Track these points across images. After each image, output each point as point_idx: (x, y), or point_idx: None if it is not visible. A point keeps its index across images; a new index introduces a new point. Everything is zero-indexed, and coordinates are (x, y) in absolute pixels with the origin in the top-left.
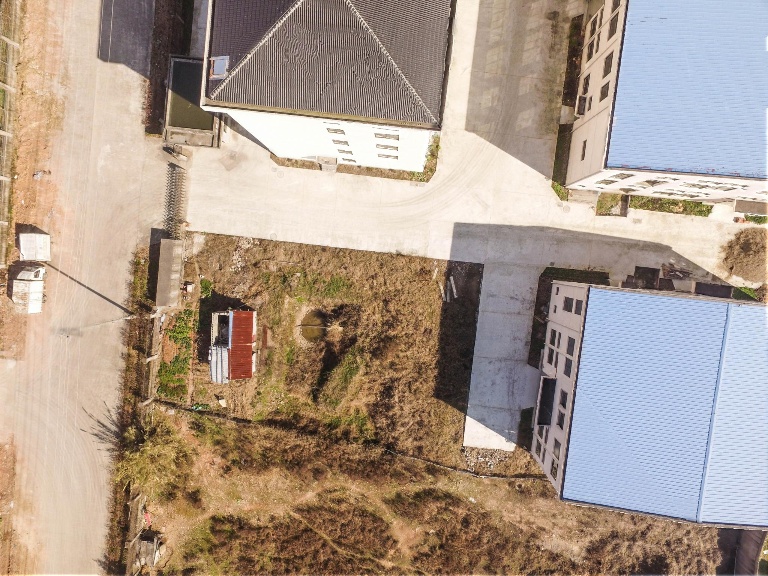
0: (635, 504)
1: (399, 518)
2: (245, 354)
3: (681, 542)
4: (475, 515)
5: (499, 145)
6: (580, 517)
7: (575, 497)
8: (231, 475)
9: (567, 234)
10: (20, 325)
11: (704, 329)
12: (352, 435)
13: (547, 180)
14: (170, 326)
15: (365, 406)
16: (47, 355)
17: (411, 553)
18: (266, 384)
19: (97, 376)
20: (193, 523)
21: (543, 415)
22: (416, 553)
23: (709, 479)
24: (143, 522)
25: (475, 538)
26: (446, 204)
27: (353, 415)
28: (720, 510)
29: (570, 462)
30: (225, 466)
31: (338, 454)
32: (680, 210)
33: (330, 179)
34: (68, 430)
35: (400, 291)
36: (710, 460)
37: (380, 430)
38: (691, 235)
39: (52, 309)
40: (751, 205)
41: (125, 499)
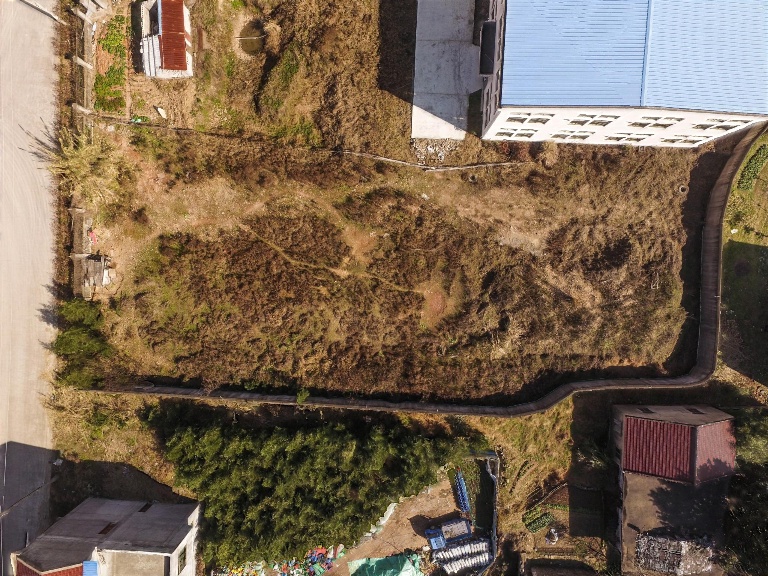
0: (576, 98)
1: (351, 223)
2: (177, 44)
3: (644, 223)
4: (429, 213)
5: None
6: (537, 206)
7: (514, 102)
8: (175, 185)
9: None
10: None
11: None
12: (298, 143)
13: None
14: (102, 35)
15: (310, 113)
16: None
17: (366, 260)
18: (205, 90)
19: (31, 91)
20: (141, 245)
21: (485, 63)
22: (371, 259)
23: (651, 59)
24: (90, 247)
25: (430, 236)
26: None
27: (299, 125)
28: (665, 93)
29: (506, 64)
30: (169, 181)
31: (284, 157)
32: None
33: None
34: (6, 151)
35: None
36: (651, 38)
37: (326, 135)
38: None
39: None
40: None
41: (69, 217)
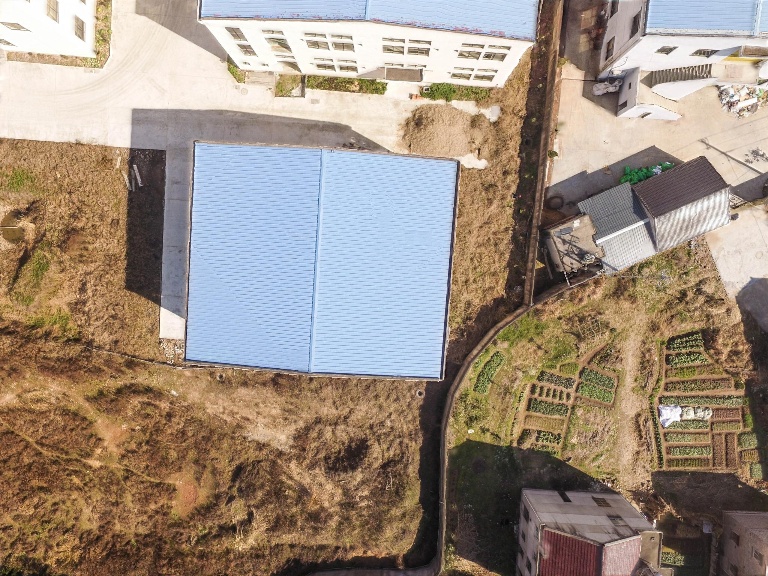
0: (252, 360)
1: (103, 416)
2: None
3: (383, 424)
4: (179, 409)
5: (171, 28)
6: (283, 405)
7: (197, 357)
8: None
9: (246, 117)
10: None
11: (301, 177)
12: (53, 335)
13: (222, 62)
14: None
15: (66, 305)
16: None
17: (118, 451)
18: None
19: None
20: None
21: None
22: (123, 451)
23: (318, 329)
24: None
25: (179, 431)
26: (122, 90)
27: (56, 315)
28: (332, 360)
29: (190, 322)
30: None
31: (34, 353)
32: (357, 89)
33: (2, 68)
34: None
35: (84, 182)
36: (317, 309)
37: (81, 328)
38: (369, 114)
39: None
40: (402, 73)
41: None
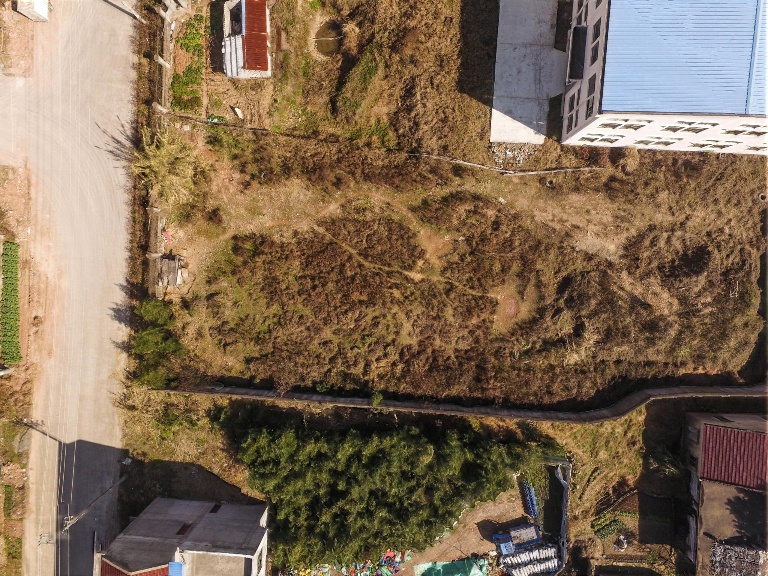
0: (679, 105)
1: (426, 226)
2: (260, 44)
3: (722, 231)
4: (505, 217)
5: None
6: (615, 212)
7: (615, 108)
8: (251, 186)
9: None
10: (27, 39)
11: None
12: (374, 145)
13: None
14: (181, 34)
15: (386, 115)
16: (56, 70)
17: (440, 263)
18: (283, 90)
19: (108, 89)
20: (214, 245)
21: (574, 68)
22: (446, 263)
23: (758, 67)
24: (163, 246)
25: (506, 240)
26: None
27: (374, 127)
28: None
29: (608, 70)
30: (244, 181)
31: (360, 159)
32: None
33: None
34: (82, 149)
35: None
36: (758, 45)
37: (403, 137)
38: None
39: (59, 20)
40: None
41: (144, 216)
